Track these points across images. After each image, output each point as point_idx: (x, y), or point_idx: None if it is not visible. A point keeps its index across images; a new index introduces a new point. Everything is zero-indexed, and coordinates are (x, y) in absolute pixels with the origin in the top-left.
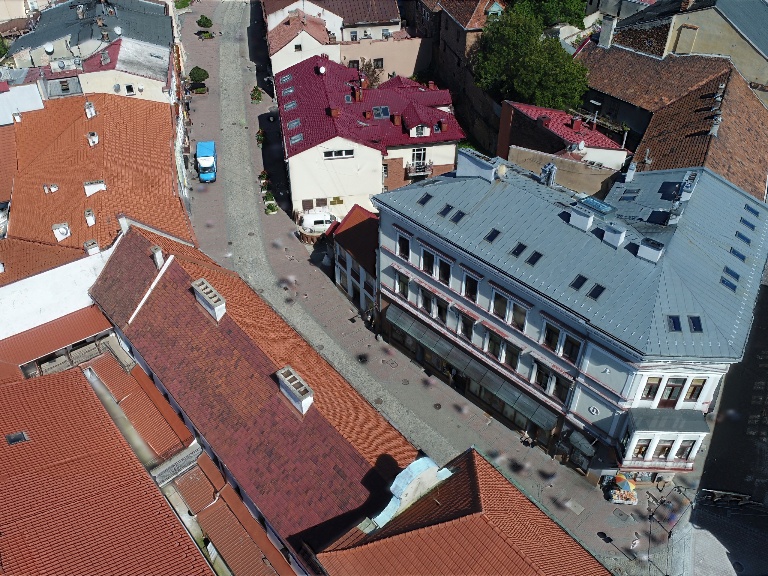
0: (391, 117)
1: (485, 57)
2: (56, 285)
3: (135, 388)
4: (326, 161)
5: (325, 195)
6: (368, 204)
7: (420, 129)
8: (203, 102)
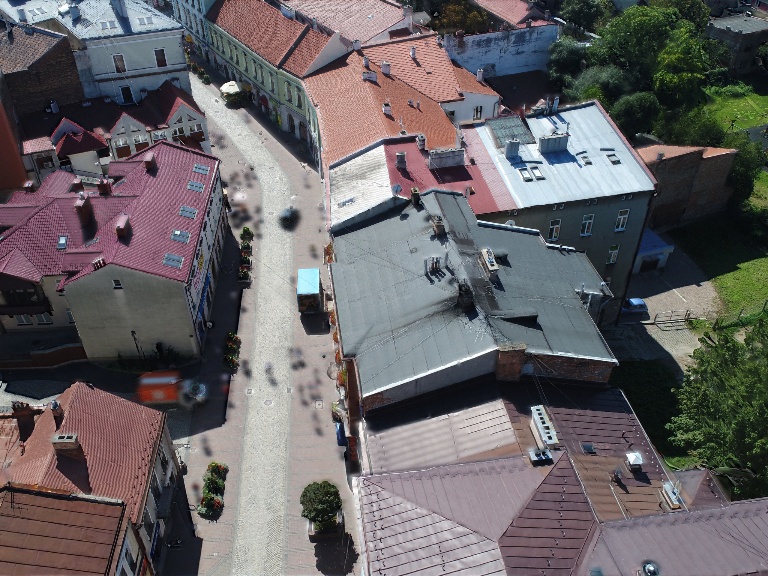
0: None
1: None
2: None
3: None
4: None
5: None
6: None
7: None
8: None
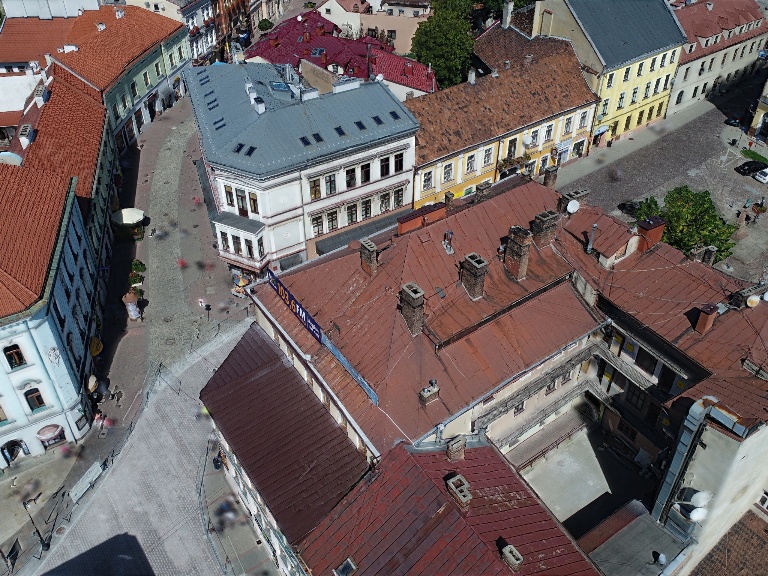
0: None
1: None
2: (6, 88)
3: None
4: None
5: None
6: None
7: (336, 67)
8: None
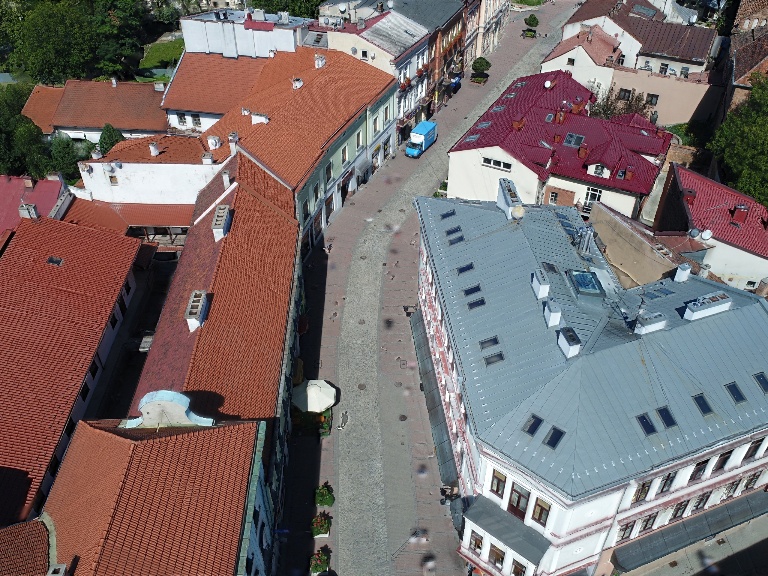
0: None
1: None
2: (175, 177)
3: None
4: (483, 167)
5: None
6: None
7: (600, 168)
8: (473, 90)
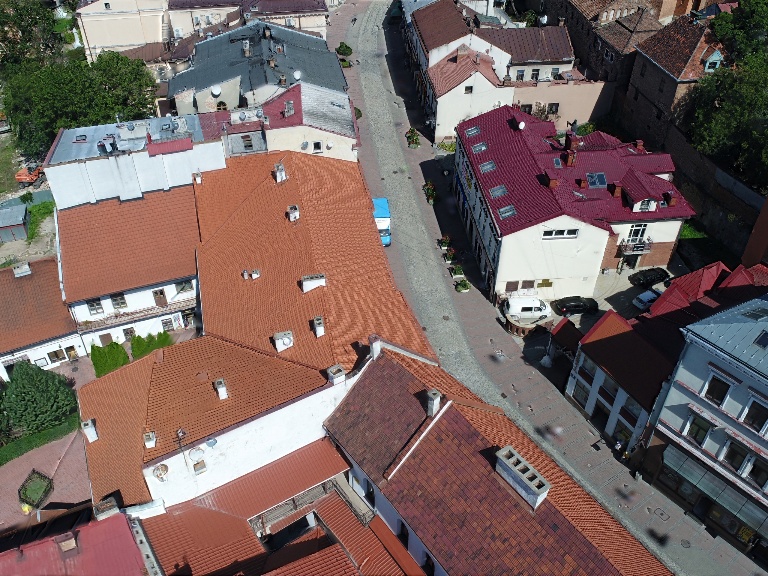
0: (608, 186)
1: (706, 115)
2: (293, 420)
3: (377, 548)
4: (544, 241)
5: (534, 277)
6: (579, 287)
7: (645, 203)
8: None
